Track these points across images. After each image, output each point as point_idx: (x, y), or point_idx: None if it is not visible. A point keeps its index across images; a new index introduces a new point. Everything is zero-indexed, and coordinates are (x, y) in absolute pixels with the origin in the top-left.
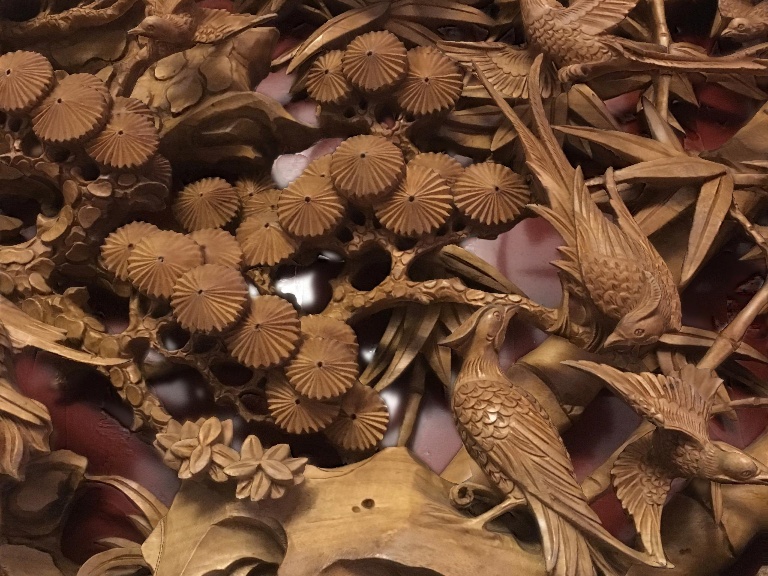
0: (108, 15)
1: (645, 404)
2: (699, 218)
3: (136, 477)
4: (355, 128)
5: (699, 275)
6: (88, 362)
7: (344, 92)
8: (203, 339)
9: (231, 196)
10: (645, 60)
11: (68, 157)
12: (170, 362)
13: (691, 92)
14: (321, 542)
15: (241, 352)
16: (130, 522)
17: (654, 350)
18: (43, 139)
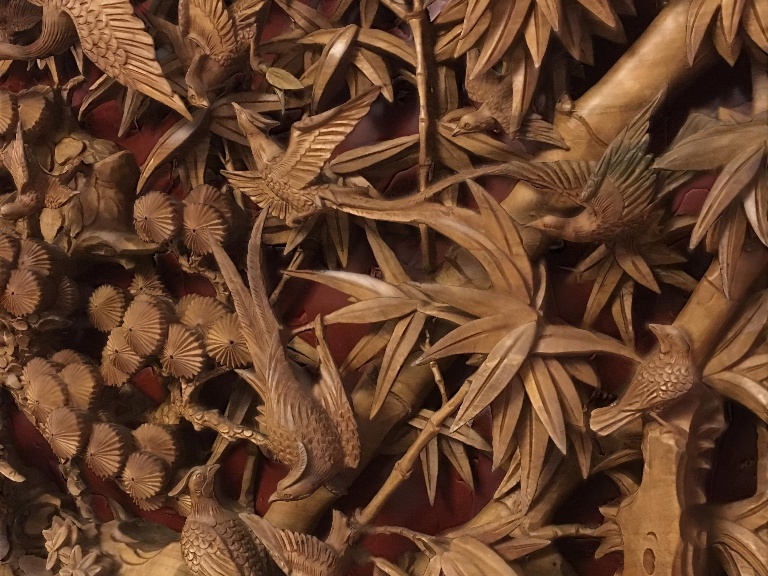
0: None
1: (278, 559)
2: (384, 362)
3: None
4: None
5: (460, 356)
6: (8, 477)
7: None
8: None
9: (116, 304)
10: (343, 209)
11: None
12: None
13: (465, 164)
14: None
15: None
16: None
17: (415, 428)
18: None
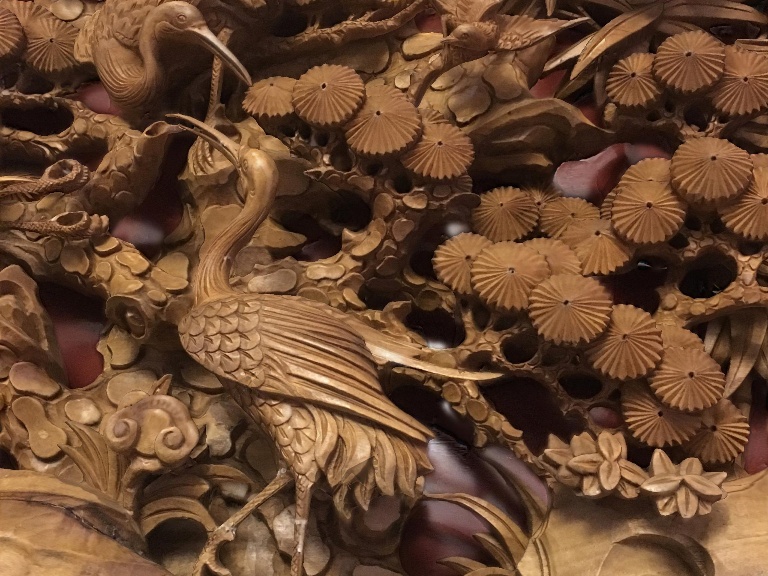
0: (389, 26)
1: None
2: None
3: (478, 494)
4: (658, 132)
5: None
6: (458, 377)
7: (653, 95)
8: (553, 351)
9: (530, 205)
10: None
11: (381, 170)
12: (511, 376)
13: None
14: (755, 560)
15: (605, 364)
16: (470, 541)
17: None
18: (362, 152)
